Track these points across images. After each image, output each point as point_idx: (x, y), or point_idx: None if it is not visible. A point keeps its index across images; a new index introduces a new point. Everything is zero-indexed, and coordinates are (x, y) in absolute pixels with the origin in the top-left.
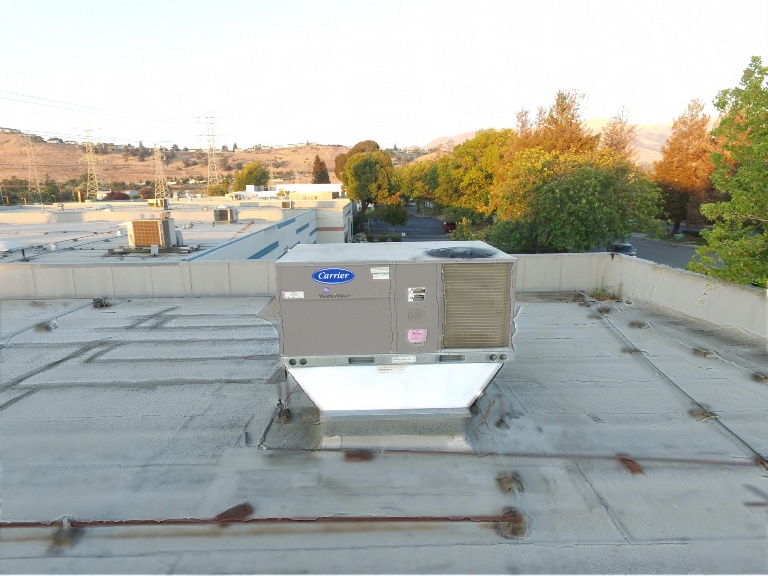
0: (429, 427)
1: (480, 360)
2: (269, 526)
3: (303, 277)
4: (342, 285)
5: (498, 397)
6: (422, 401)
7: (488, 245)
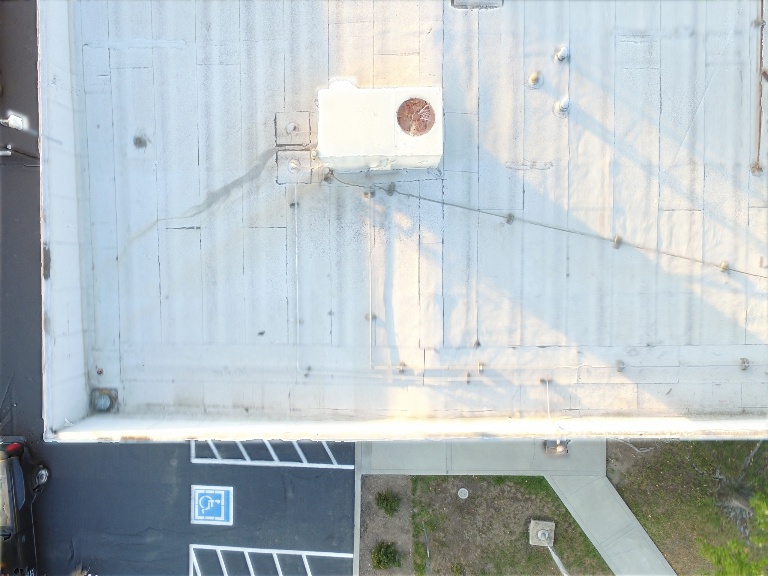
0: None
1: None
2: (759, 91)
3: None
4: None
5: None
6: None
7: None
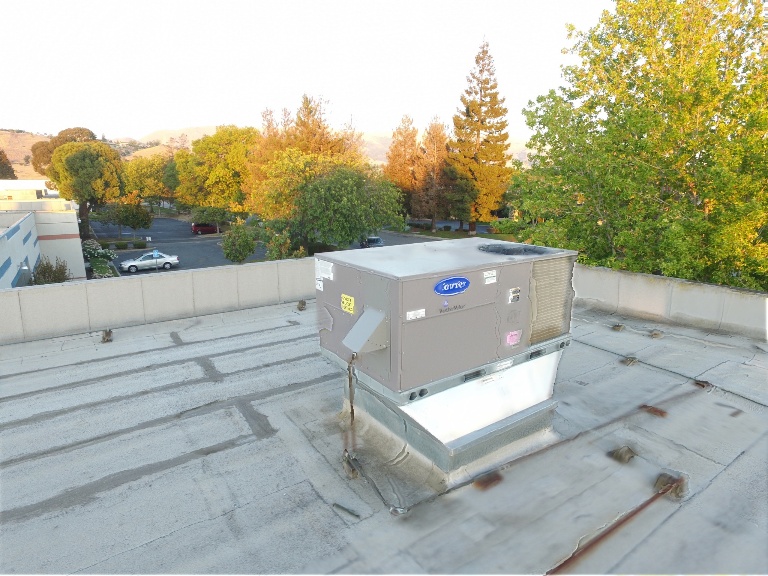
0: (531, 426)
1: (552, 350)
2: None
3: (426, 291)
4: (462, 295)
5: None
6: (520, 403)
7: (504, 241)
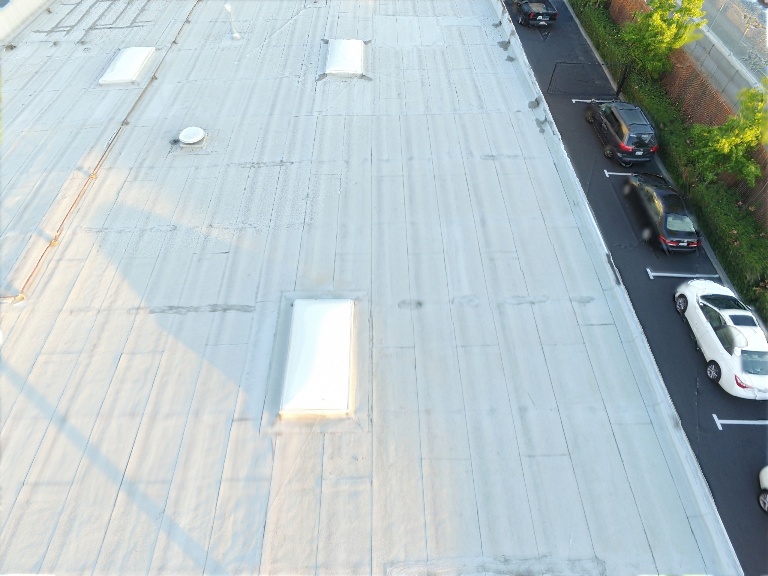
0: None
1: None
2: None
3: None
4: None
5: None
6: None
7: None
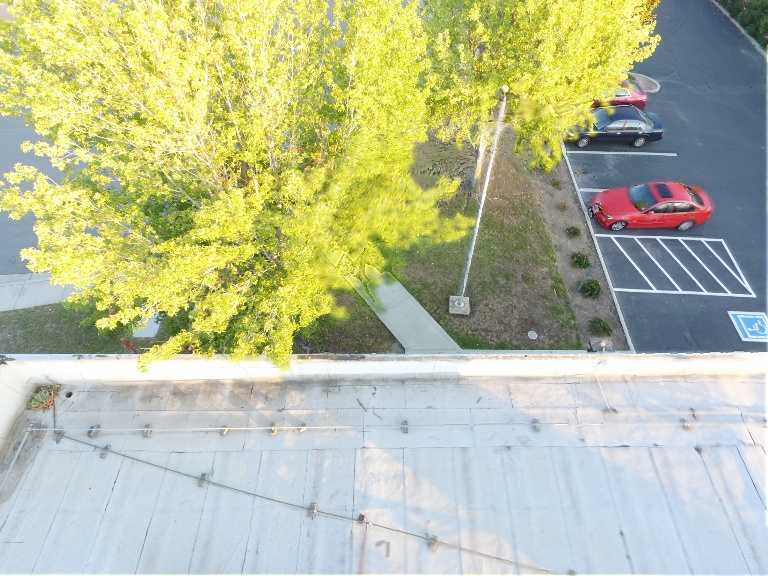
0: None
1: None
2: None
3: None
4: None
5: None
6: None
7: None
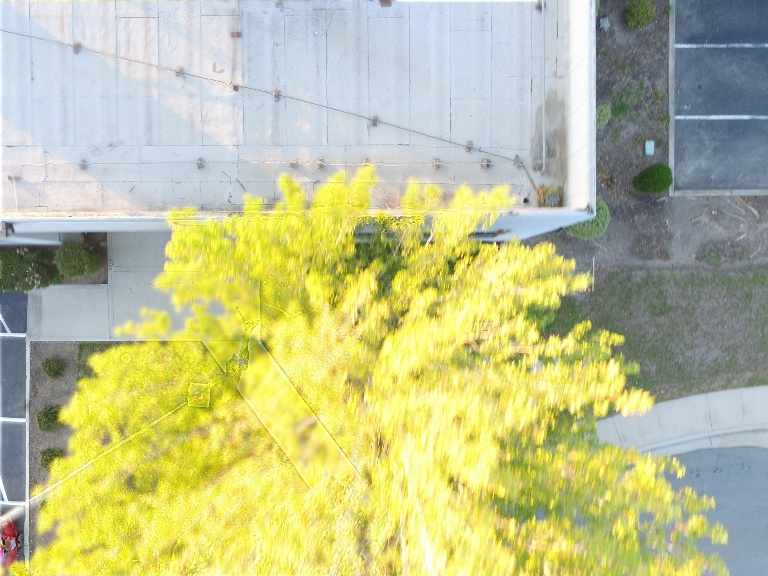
0: None
1: None
2: None
3: None
4: None
5: (303, 5)
6: None
7: None
